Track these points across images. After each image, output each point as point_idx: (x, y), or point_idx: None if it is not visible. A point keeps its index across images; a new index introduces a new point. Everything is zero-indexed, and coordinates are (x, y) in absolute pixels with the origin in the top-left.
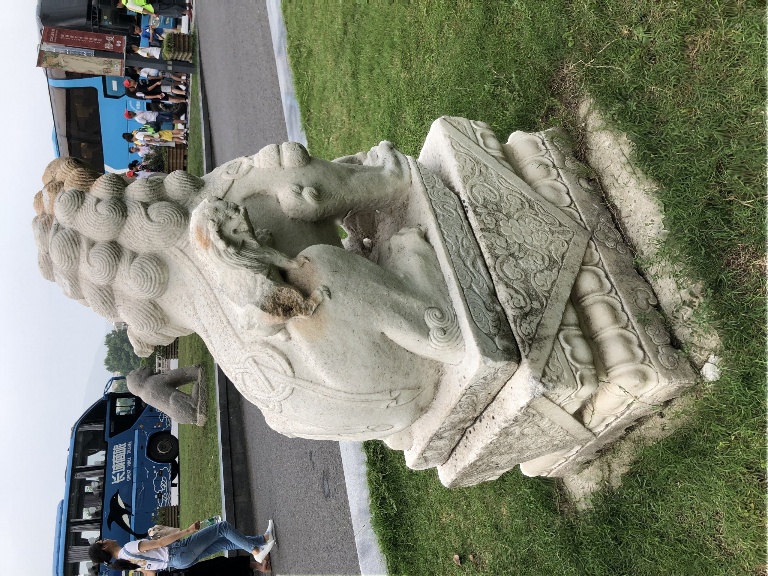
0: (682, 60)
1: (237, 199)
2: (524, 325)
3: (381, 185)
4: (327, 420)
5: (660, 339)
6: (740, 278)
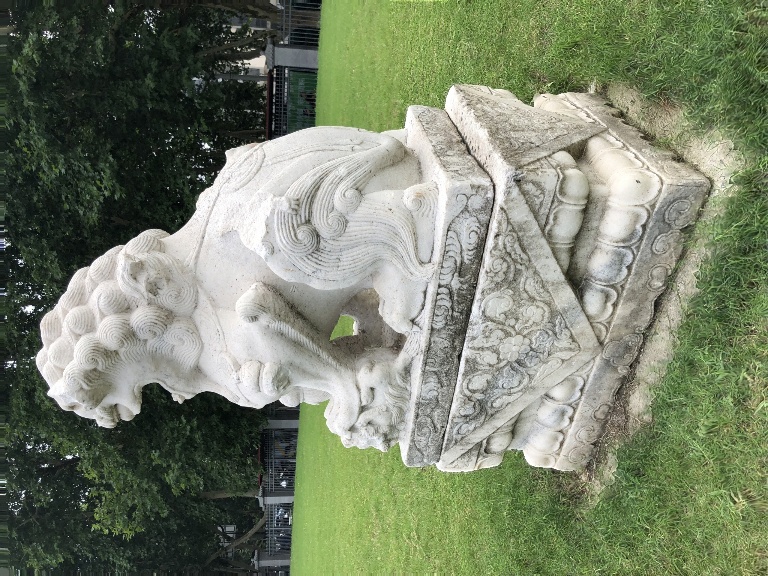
0: None
1: None
2: None
3: None
4: (306, 135)
5: None
6: None
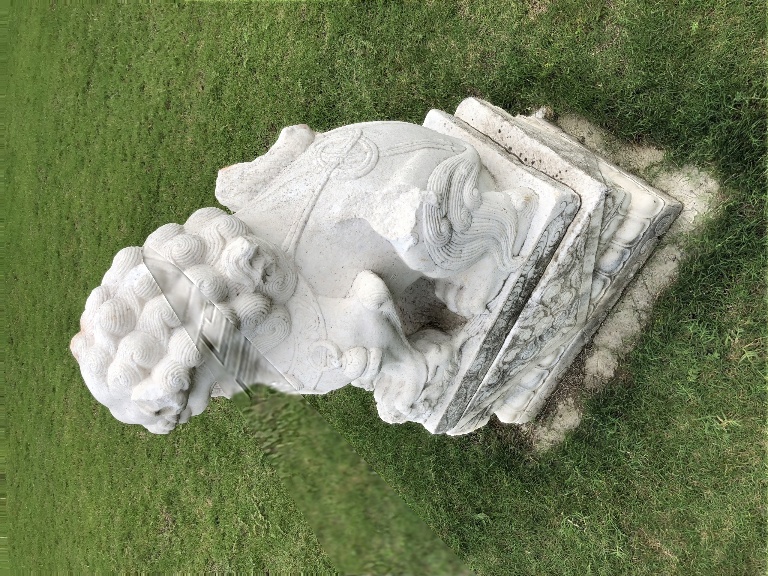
0: None
1: None
2: None
3: None
4: (406, 130)
5: None
6: None
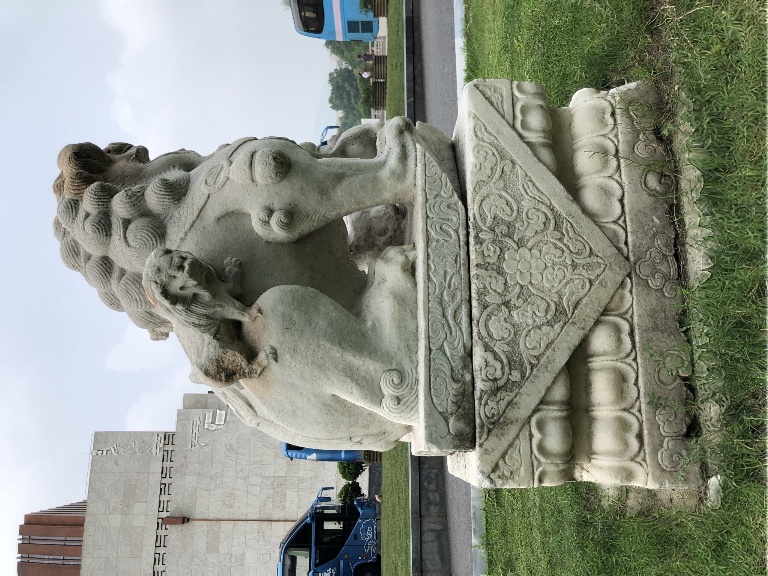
0: (763, 96)
1: (211, 219)
2: (490, 404)
3: (375, 192)
4: None
5: (672, 428)
6: (763, 420)
